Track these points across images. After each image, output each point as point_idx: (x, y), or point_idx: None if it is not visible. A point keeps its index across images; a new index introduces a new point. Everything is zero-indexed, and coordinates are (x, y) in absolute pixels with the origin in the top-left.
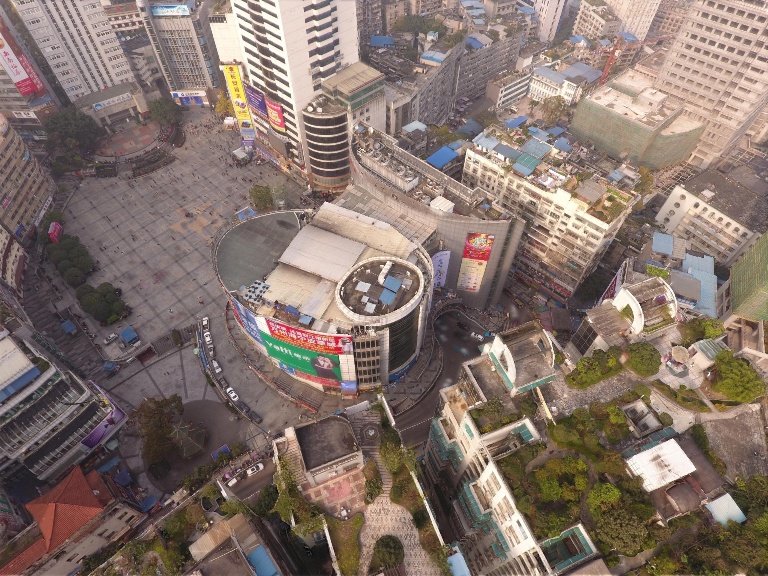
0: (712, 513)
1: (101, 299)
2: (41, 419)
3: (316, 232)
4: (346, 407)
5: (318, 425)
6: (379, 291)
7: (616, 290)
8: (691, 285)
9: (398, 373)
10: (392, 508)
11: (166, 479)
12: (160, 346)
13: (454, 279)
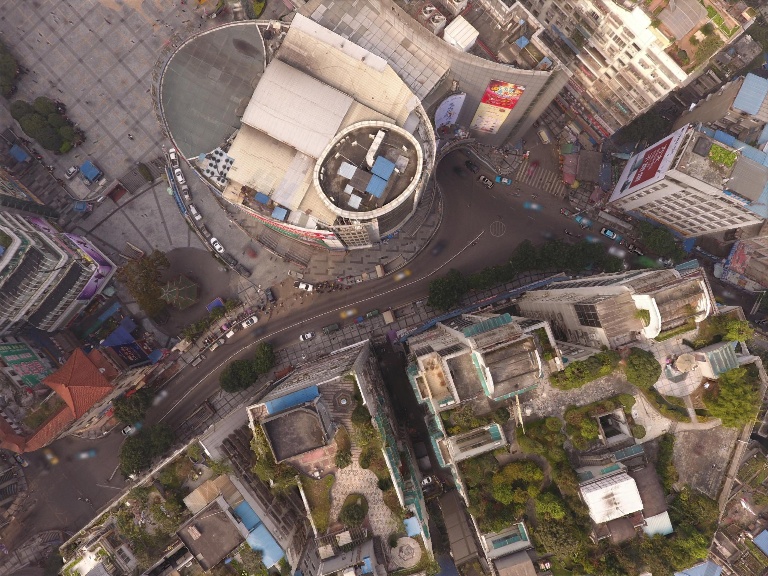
0: (644, 527)
1: (43, 122)
2: (27, 288)
3: (286, 74)
4: (317, 383)
5: (287, 417)
6: (366, 179)
7: (662, 164)
8: (757, 178)
9: (391, 233)
10: (360, 470)
11: (168, 325)
12: (129, 182)
13: (467, 119)
